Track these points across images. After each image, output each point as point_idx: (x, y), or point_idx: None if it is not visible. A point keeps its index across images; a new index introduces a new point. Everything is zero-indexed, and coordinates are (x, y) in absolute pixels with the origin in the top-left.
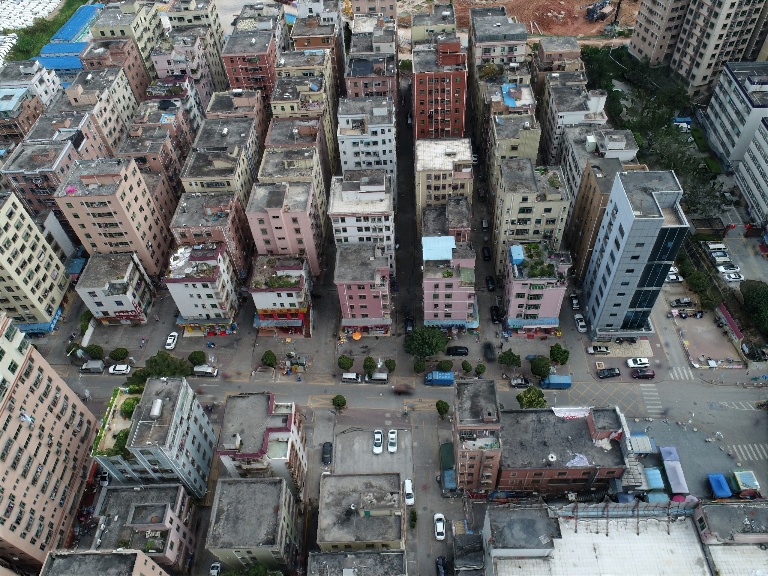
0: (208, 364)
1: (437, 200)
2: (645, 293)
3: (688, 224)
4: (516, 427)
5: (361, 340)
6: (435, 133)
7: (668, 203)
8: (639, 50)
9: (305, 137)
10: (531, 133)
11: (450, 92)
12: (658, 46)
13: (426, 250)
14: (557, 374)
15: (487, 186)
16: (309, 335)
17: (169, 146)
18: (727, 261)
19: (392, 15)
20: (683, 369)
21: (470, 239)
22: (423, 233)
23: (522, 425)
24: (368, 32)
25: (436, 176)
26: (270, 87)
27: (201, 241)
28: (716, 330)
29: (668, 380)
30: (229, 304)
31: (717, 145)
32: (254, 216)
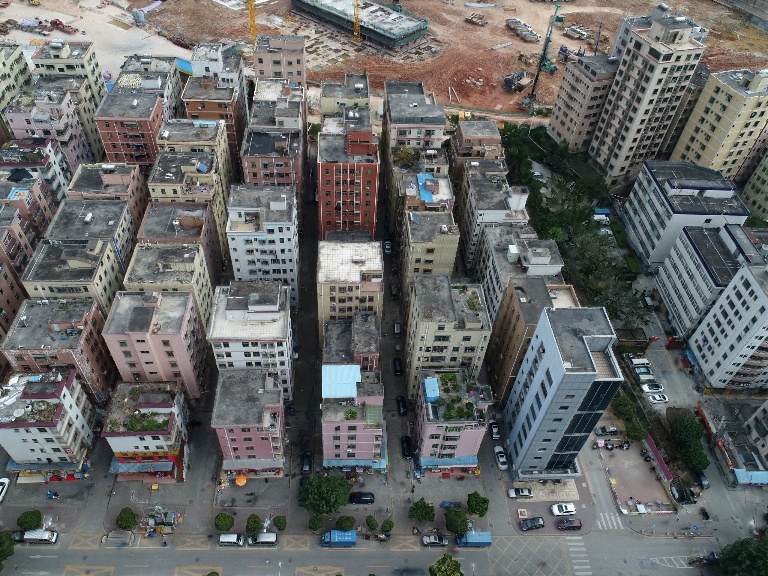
0: (45, 526)
1: (342, 312)
2: (573, 438)
3: (622, 377)
4: None
5: (247, 484)
6: (343, 225)
7: (599, 347)
8: (558, 133)
9: (188, 229)
10: (449, 237)
11: (360, 184)
12: (577, 132)
13: (326, 384)
14: (475, 526)
15: (400, 283)
16: (182, 479)
17: (17, 230)
18: (651, 379)
19: (300, 81)
20: (611, 516)
21: (380, 347)
22: (324, 355)
23: None
24: (271, 100)
25: (341, 288)
26: (154, 156)
27: (44, 364)
28: (643, 465)
29: (596, 531)
30: (78, 444)
31: (636, 243)
32: (113, 338)
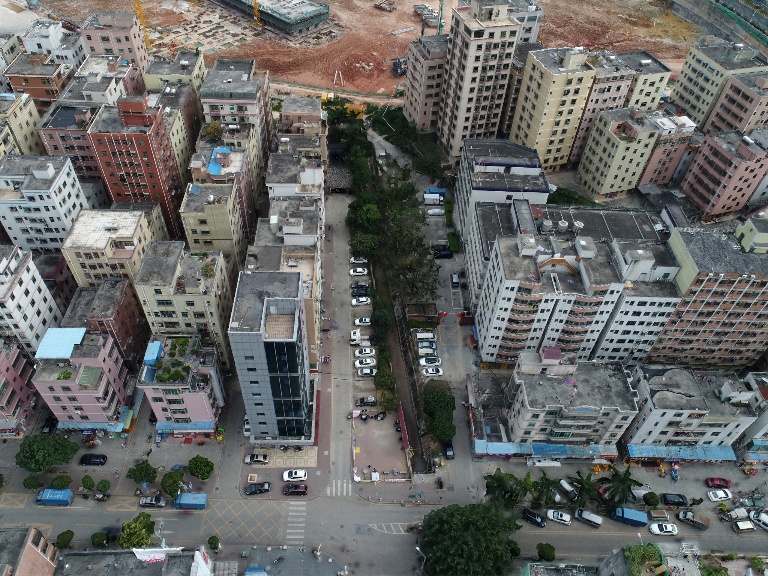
0: None
1: (98, 279)
2: (286, 403)
3: (295, 338)
4: (83, 575)
5: None
6: (134, 197)
7: (289, 310)
8: (409, 114)
9: None
10: (216, 208)
11: (137, 155)
12: (421, 112)
13: (43, 346)
14: (200, 489)
15: None
16: None
17: None
18: (430, 353)
19: (133, 59)
20: (343, 483)
21: None
22: (65, 320)
23: (92, 572)
24: None
25: (86, 254)
26: None
27: None
28: (393, 435)
29: (322, 496)
30: None
31: (457, 222)
32: None
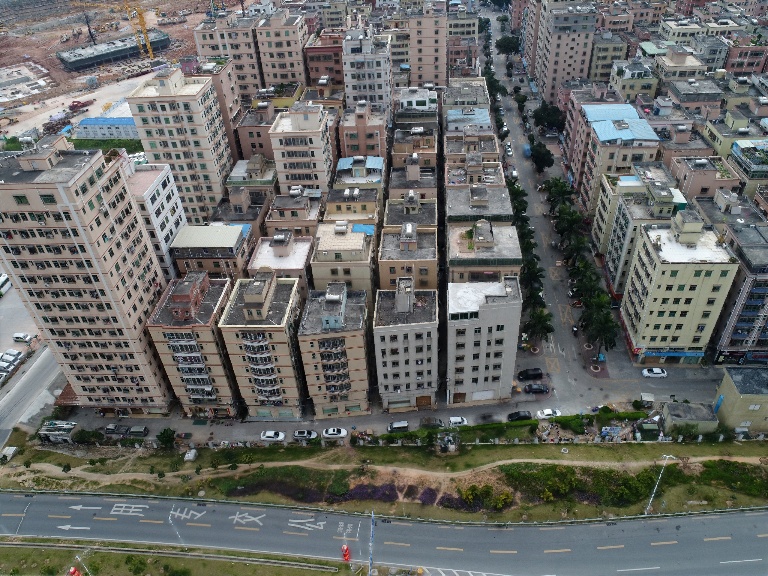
0: None
1: None
2: None
3: None
4: None
5: None
6: None
7: None
8: None
9: None
10: None
11: None
12: None
13: (457, 2)
14: None
15: None
16: None
17: None
18: None
19: None
20: None
21: None
22: None
23: None
24: (305, 2)
25: None
26: None
27: None
28: None
29: None
30: None
31: None
32: None
